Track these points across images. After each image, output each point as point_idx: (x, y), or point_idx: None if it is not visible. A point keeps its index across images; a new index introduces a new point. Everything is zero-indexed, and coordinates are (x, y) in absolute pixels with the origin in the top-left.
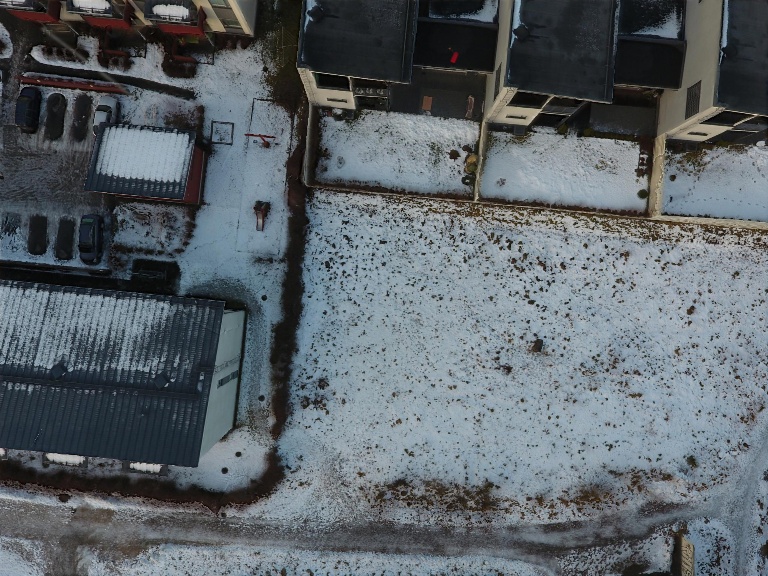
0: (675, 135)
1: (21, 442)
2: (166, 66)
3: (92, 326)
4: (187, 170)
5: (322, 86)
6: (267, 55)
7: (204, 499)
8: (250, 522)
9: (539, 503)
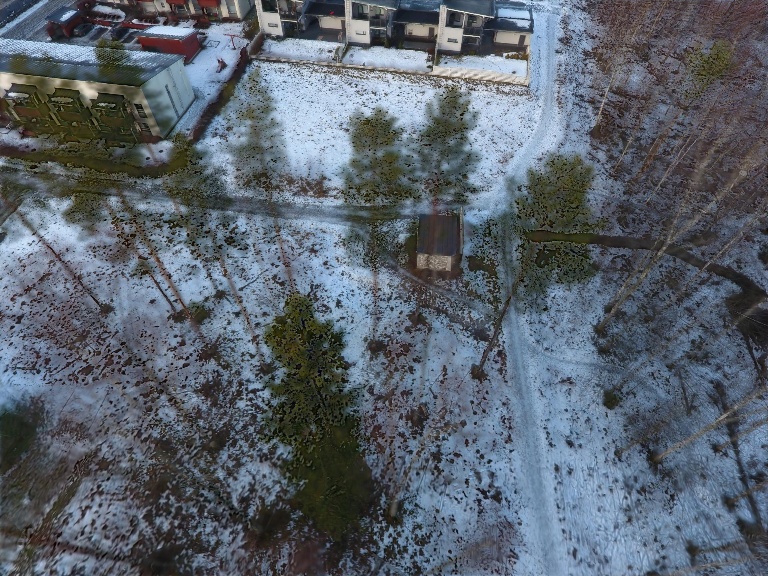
0: (441, 41)
1: None
2: (195, 25)
3: None
4: (189, 34)
5: (265, 11)
6: (246, 25)
7: None
8: (152, 187)
9: (358, 192)
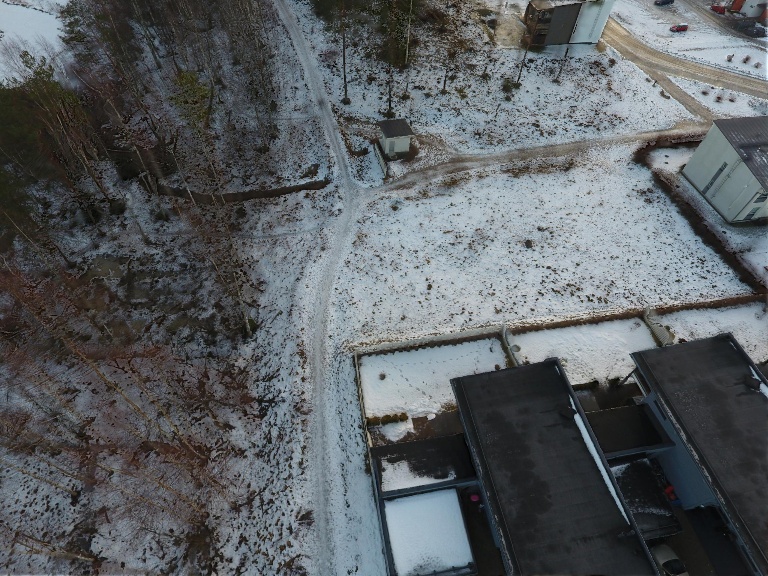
0: None
1: None
2: None
3: None
4: None
5: None
6: None
7: (668, 143)
8: (633, 143)
9: None
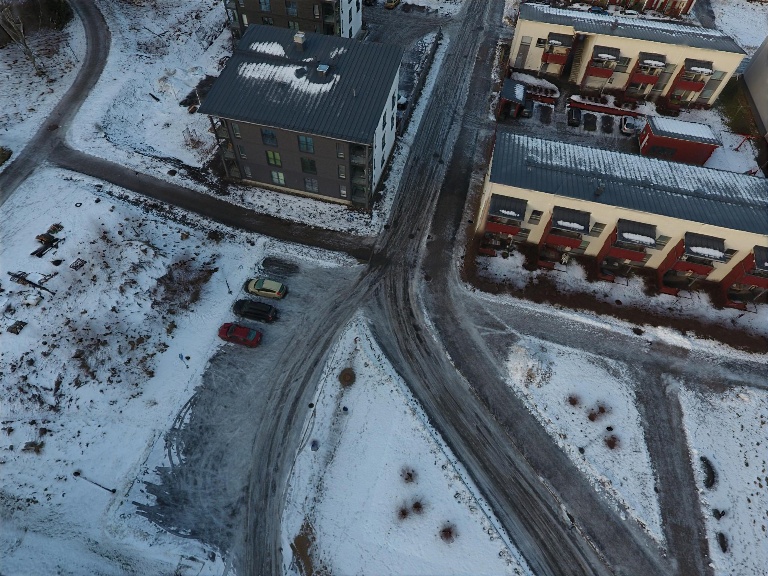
0: None
1: (697, 218)
2: (660, 110)
3: (709, 178)
4: None
5: None
6: (722, 114)
7: None
8: None
9: None
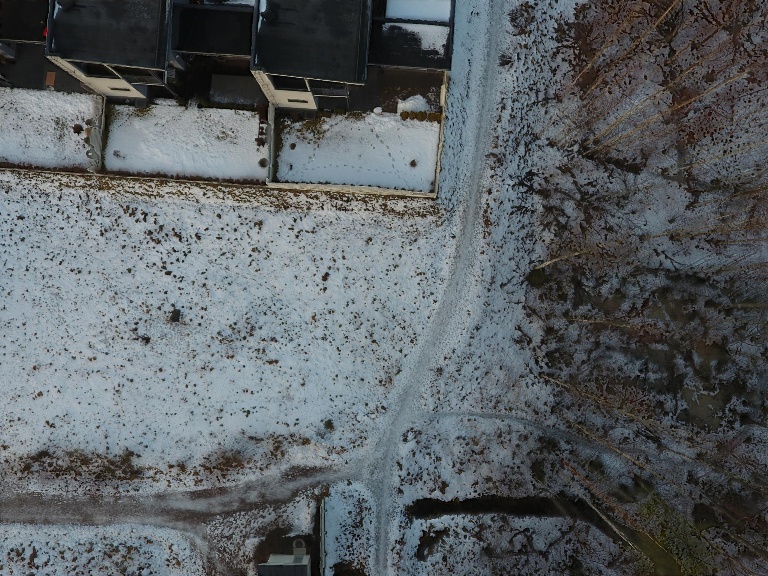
0: None
1: None
2: None
3: None
4: None
5: None
6: None
7: None
8: None
9: (182, 470)
